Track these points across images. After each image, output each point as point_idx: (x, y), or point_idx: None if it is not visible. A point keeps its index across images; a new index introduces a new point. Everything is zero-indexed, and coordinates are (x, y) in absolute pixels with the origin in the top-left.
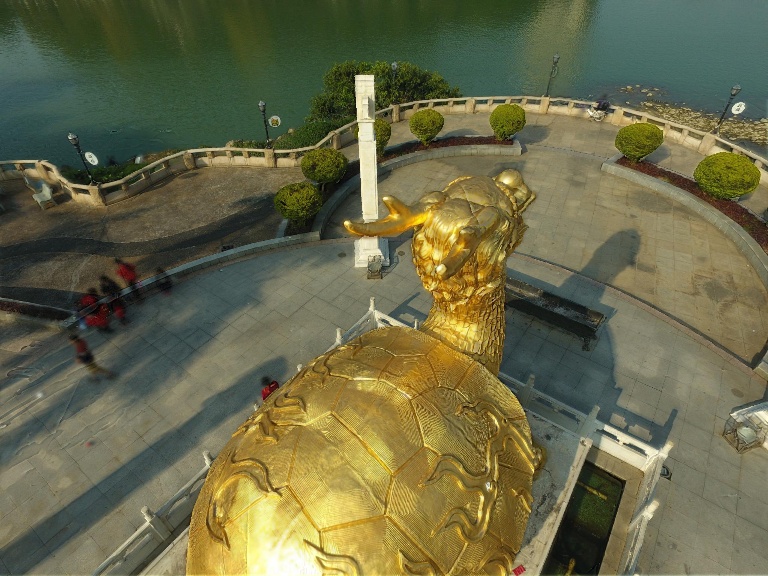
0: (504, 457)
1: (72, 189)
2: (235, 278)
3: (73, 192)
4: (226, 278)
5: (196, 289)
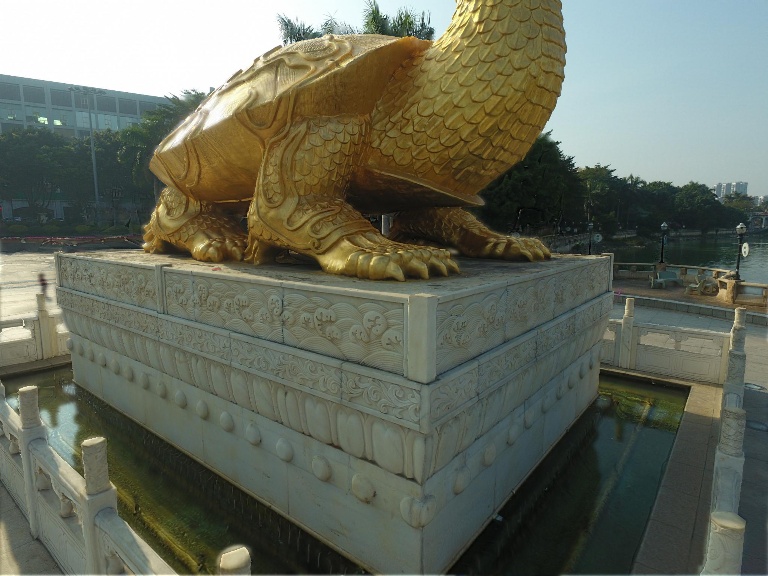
0: (287, 70)
1: (719, 283)
2: (697, 322)
3: (719, 287)
4: (690, 319)
5: (650, 313)
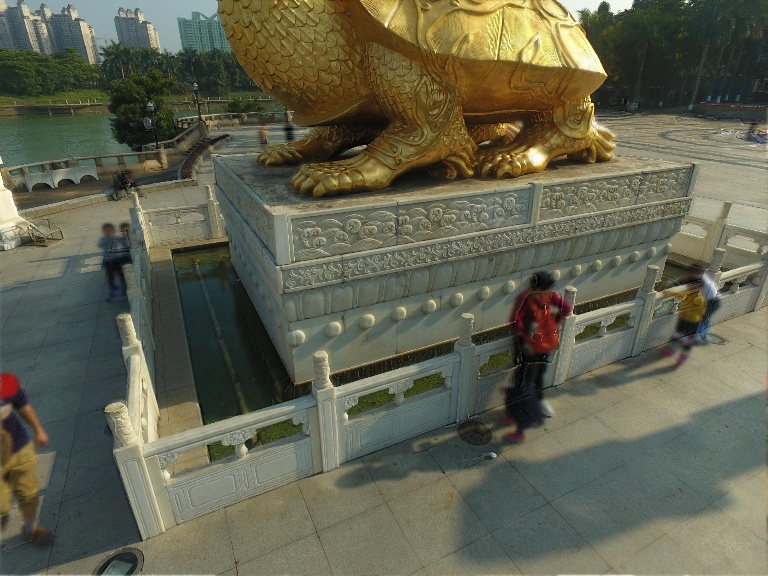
0: None
1: None
2: None
3: None
4: None
5: None
